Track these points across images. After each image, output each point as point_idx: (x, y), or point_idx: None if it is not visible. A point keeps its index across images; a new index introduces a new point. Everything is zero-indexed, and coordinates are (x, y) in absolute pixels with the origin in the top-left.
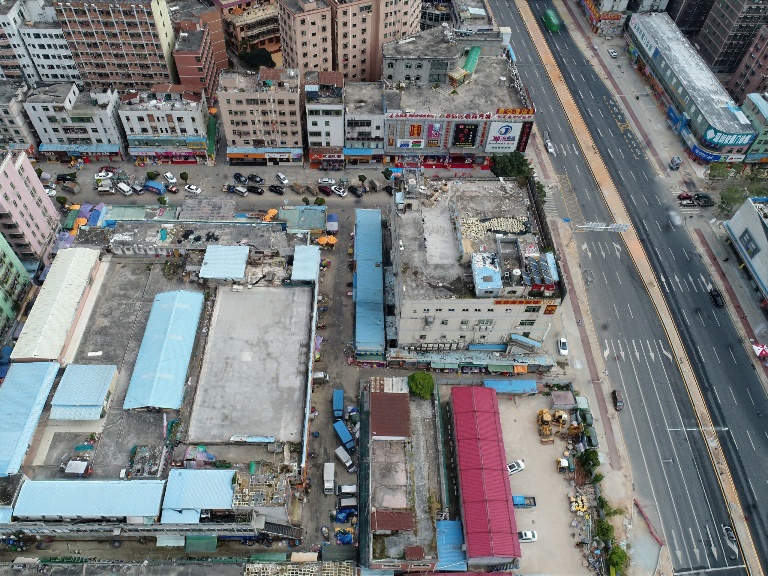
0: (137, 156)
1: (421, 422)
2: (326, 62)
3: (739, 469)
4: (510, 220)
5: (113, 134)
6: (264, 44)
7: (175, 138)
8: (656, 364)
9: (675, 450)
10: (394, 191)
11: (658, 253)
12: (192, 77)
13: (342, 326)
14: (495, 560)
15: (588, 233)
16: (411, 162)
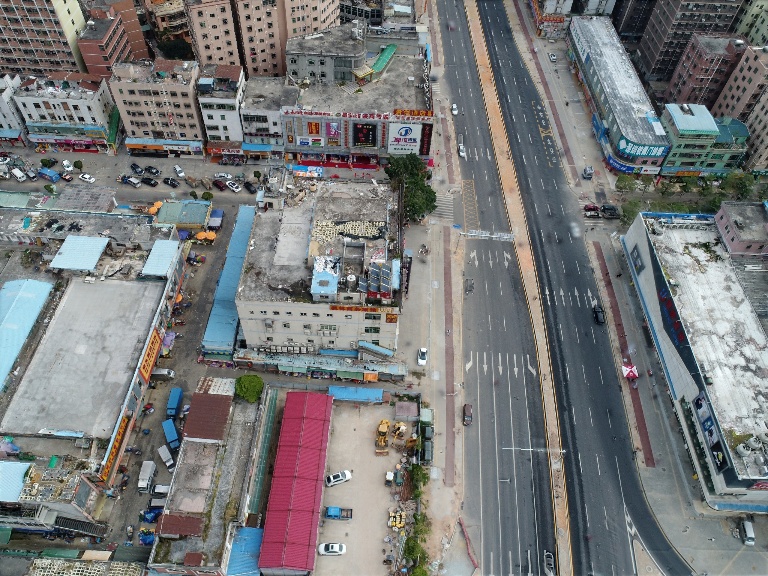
0: (38, 143)
1: (241, 426)
2: (232, 55)
3: (578, 494)
4: (366, 224)
5: (12, 120)
6: (189, 35)
7: (73, 126)
8: (518, 379)
9: (515, 470)
10: None
11: (549, 265)
12: (98, 66)
13: (202, 323)
14: (288, 572)
15: (480, 241)
16: (315, 160)
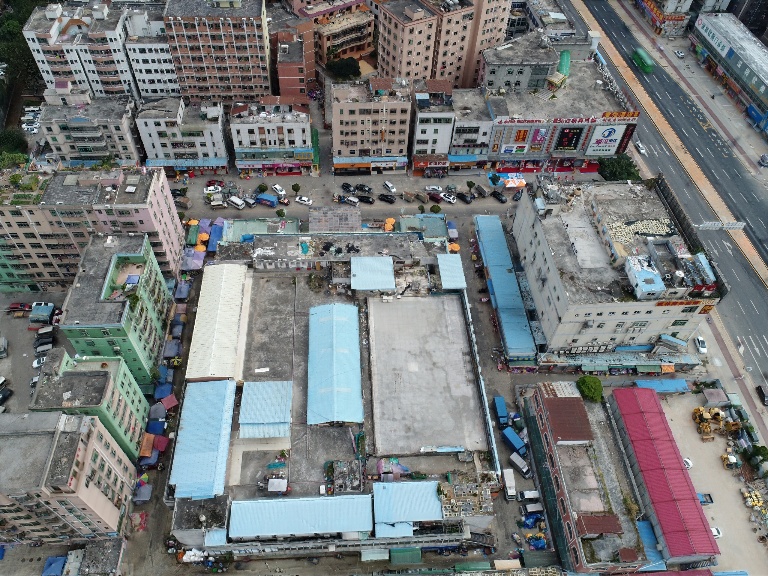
0: (242, 169)
1: (597, 425)
2: (426, 70)
3: None
4: (653, 222)
5: (221, 148)
6: (345, 53)
7: (283, 150)
8: None
9: None
10: (530, 197)
11: (767, 249)
12: (292, 88)
13: (483, 333)
14: (694, 558)
15: None
16: (511, 167)
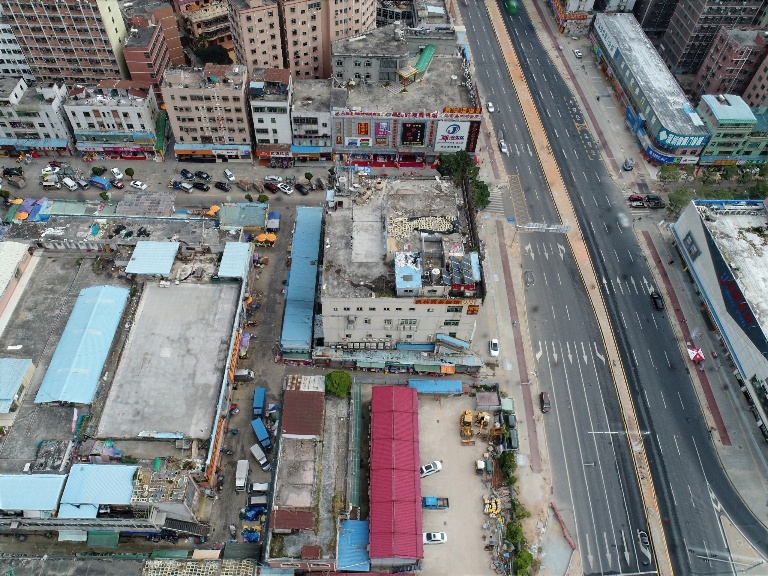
0: (85, 151)
1: (335, 421)
2: (276, 59)
3: (661, 474)
4: (439, 219)
5: (60, 129)
6: (223, 41)
7: (122, 134)
8: (588, 366)
9: (598, 453)
10: (327, 189)
11: (602, 255)
12: (142, 73)
13: (273, 324)
14: (398, 561)
15: (533, 234)
16: (361, 160)
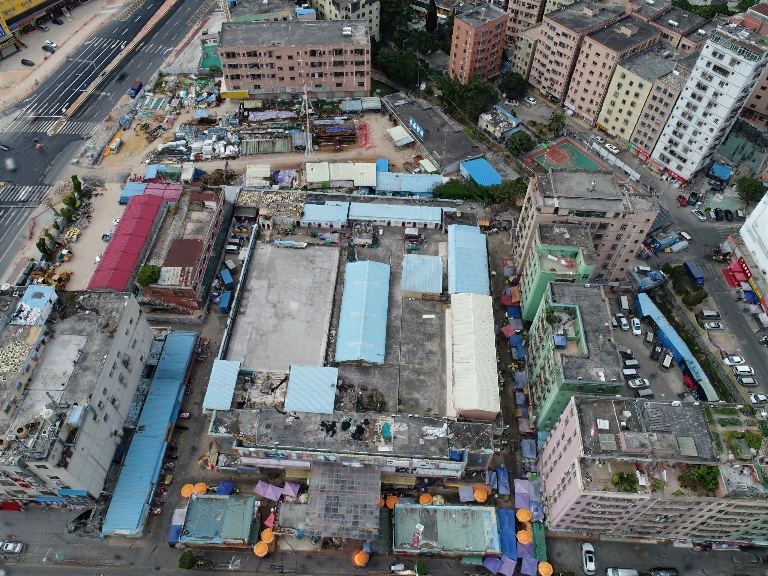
0: None
1: (161, 256)
2: None
3: None
4: None
5: None
6: None
7: None
8: None
9: None
10: (77, 437)
11: None
12: None
13: (206, 380)
14: None
15: None
16: None
